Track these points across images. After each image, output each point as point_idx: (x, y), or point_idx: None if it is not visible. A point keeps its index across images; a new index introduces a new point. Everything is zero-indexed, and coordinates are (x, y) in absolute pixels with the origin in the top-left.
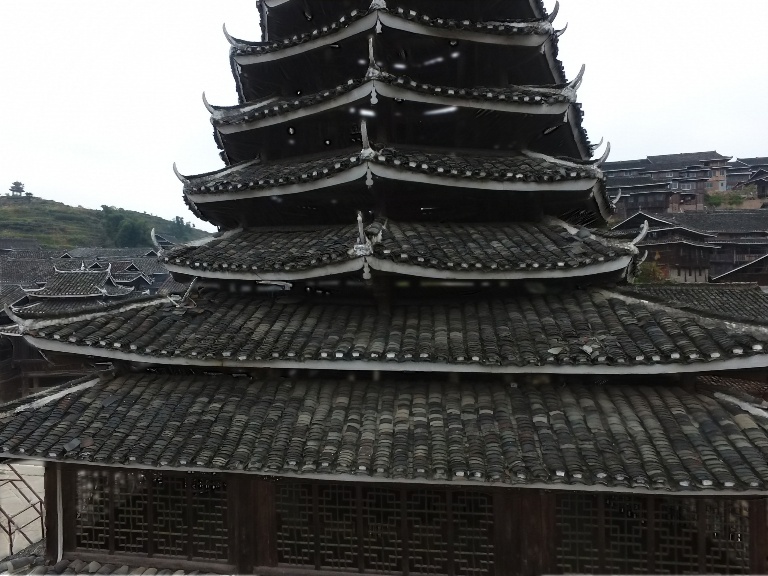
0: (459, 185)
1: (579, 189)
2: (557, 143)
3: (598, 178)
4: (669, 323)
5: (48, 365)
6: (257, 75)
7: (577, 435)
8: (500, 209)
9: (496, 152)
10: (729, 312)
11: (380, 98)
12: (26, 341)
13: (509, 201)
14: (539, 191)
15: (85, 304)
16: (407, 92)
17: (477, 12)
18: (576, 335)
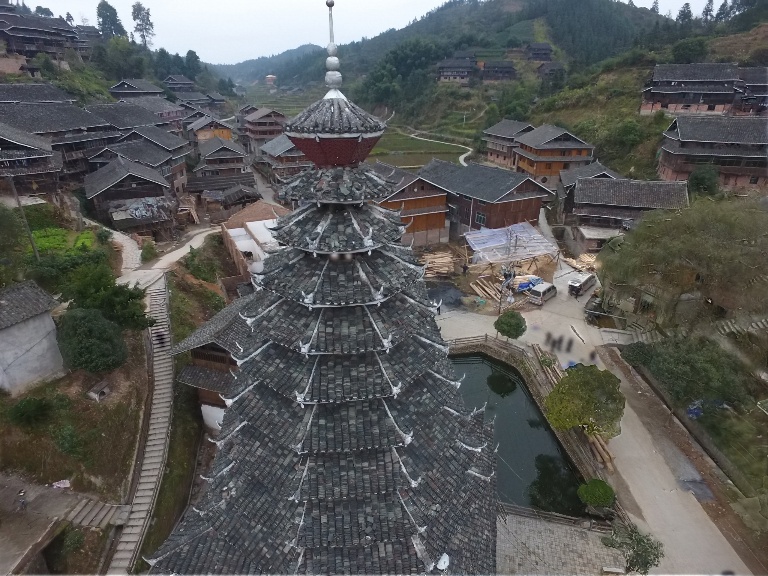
0: None
1: None
2: None
3: None
4: (470, 421)
5: None
6: None
7: None
8: None
9: None
10: None
11: None
12: None
13: None
14: None
15: None
16: None
17: None
18: None
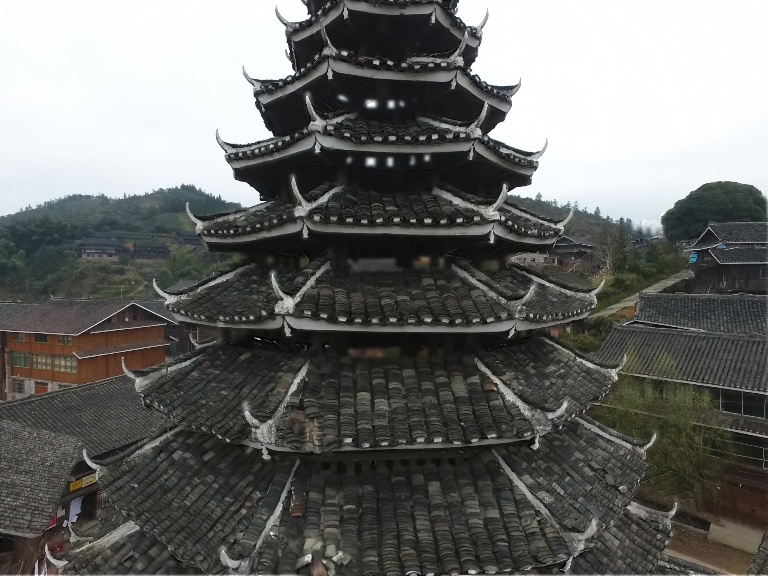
0: None
1: None
2: None
3: None
4: None
5: None
6: None
7: None
8: None
9: None
10: (2, 442)
11: None
12: None
13: None
14: None
15: None
16: None
17: None
18: None
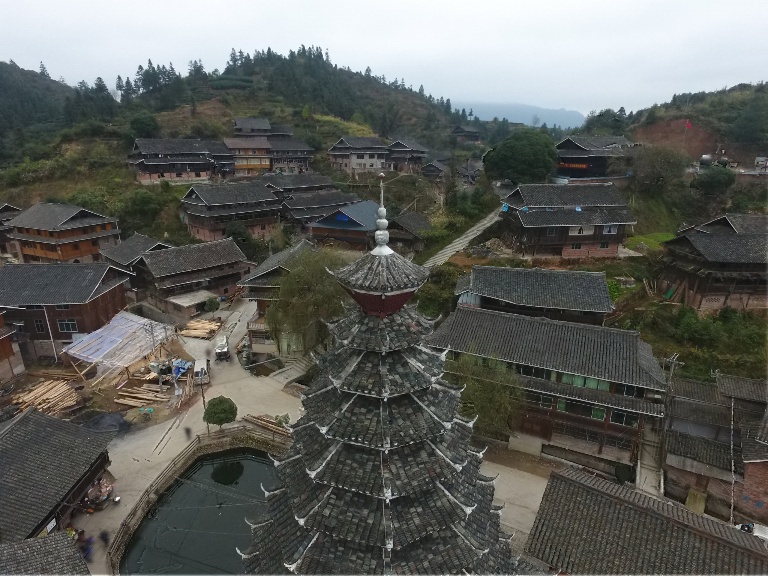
0: None
1: None
2: None
3: None
4: None
5: None
6: None
7: None
8: None
9: None
10: (16, 575)
11: None
12: None
13: None
14: None
15: None
16: None
17: None
18: None
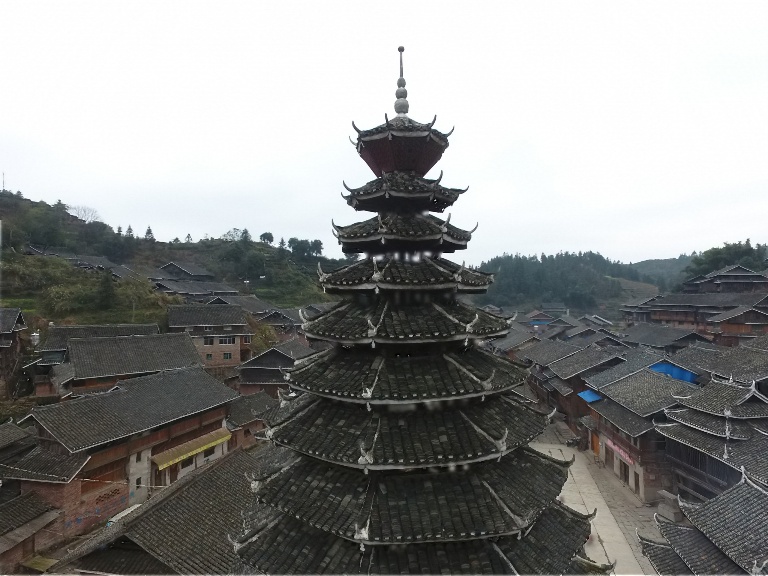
0: None
1: None
2: None
3: None
4: None
5: (686, 469)
6: None
7: None
8: None
9: None
10: None
11: None
12: (672, 441)
13: None
14: None
15: (716, 421)
16: None
17: None
18: None
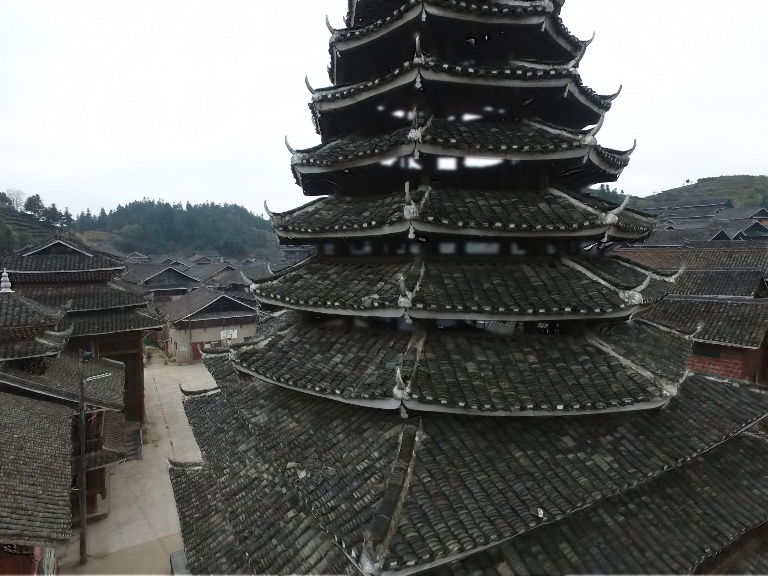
0: (304, 309)
1: (393, 316)
2: (462, 242)
3: (405, 307)
4: None
5: None
6: (314, 193)
7: (287, 538)
8: (365, 322)
9: (399, 258)
10: None
11: (281, 238)
12: None
13: (355, 319)
14: (359, 316)
15: None
16: (291, 233)
17: (421, 105)
18: (322, 459)
